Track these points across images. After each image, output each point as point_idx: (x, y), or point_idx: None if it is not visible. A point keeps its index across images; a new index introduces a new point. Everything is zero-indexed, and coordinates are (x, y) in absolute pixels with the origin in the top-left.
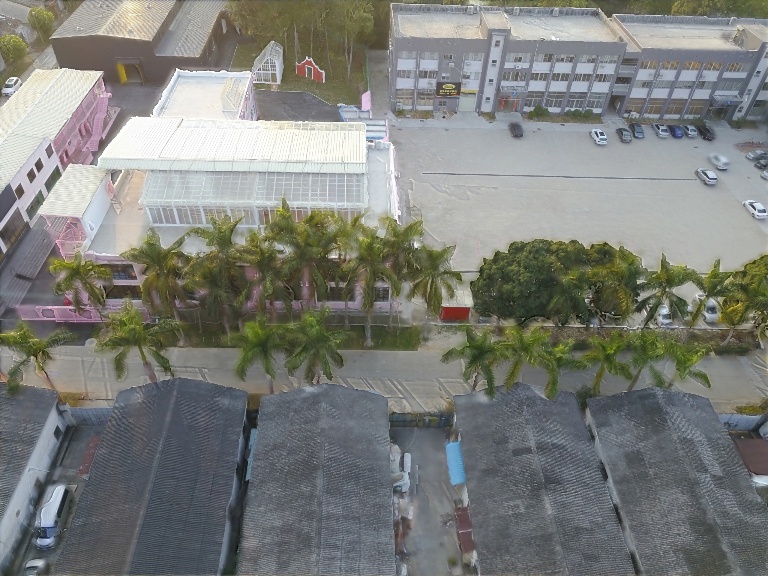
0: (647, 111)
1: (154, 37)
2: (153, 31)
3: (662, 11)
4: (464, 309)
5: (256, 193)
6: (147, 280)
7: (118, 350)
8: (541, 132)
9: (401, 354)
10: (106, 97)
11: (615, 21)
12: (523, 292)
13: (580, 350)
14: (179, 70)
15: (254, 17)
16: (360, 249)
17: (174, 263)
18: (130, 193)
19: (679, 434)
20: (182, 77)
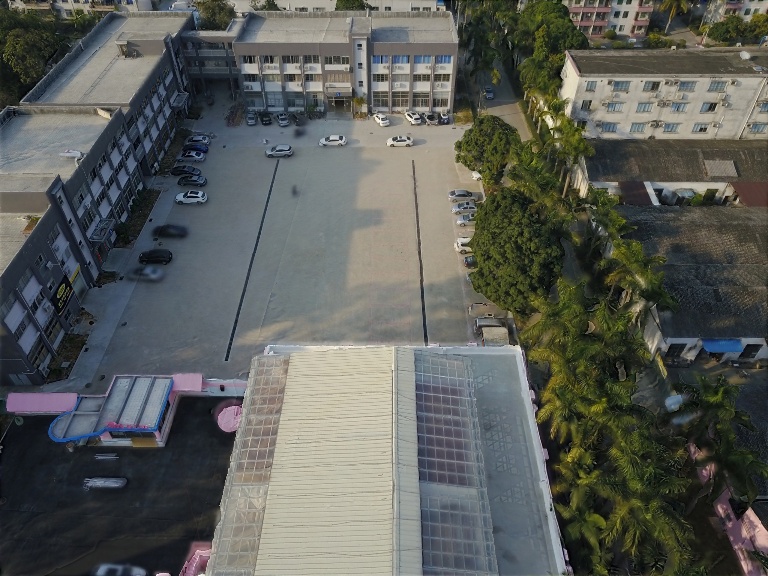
0: None
1: None
2: None
3: None
4: None
5: (462, 486)
6: None
7: None
8: (163, 239)
9: None
10: None
11: None
12: None
13: None
14: None
15: None
16: None
17: None
18: None
19: None
20: None
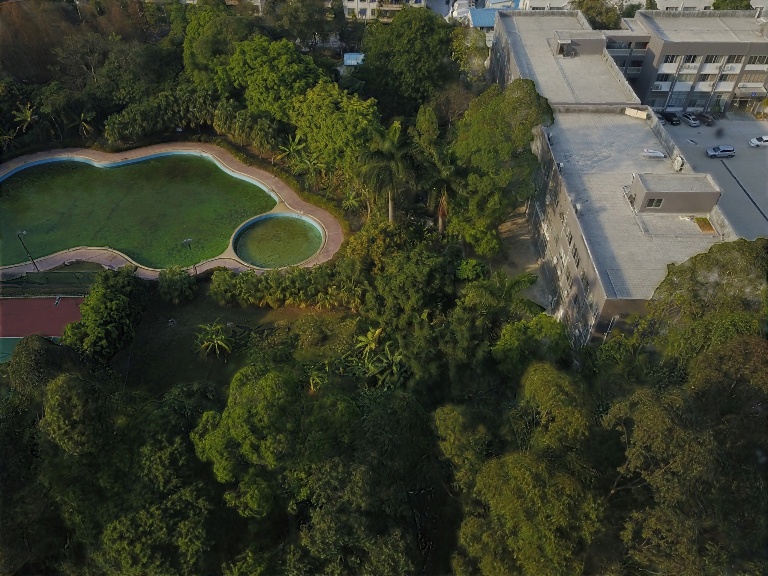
0: None
1: None
2: None
3: (438, 77)
4: None
5: None
6: None
7: None
8: None
9: None
10: None
11: None
12: None
13: None
14: None
15: None
16: None
17: None
18: None
19: None
20: None
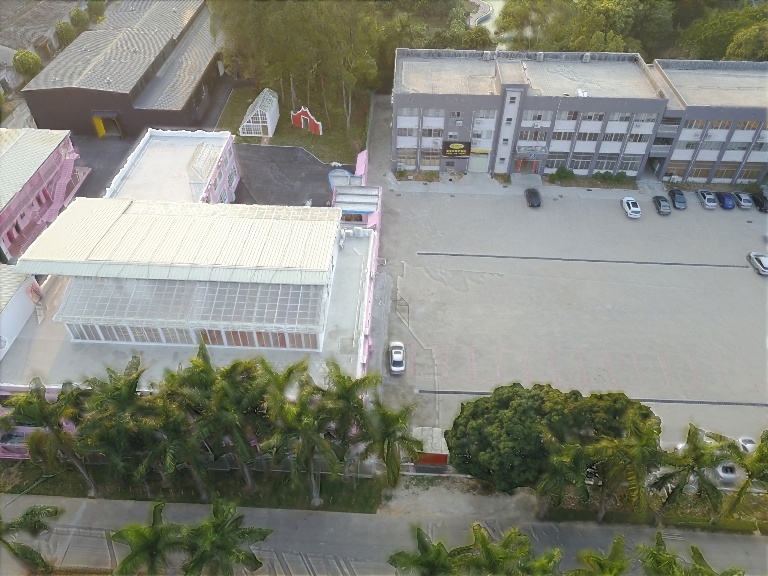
0: (692, 174)
1: (133, 88)
2: (133, 81)
3: (715, 51)
4: (440, 456)
5: (191, 309)
6: (33, 438)
7: (17, 500)
8: (563, 200)
9: (355, 518)
10: (72, 159)
11: (657, 68)
12: (504, 464)
13: (582, 521)
14: (152, 129)
15: (247, 62)
16: (286, 419)
17: (73, 411)
18: (60, 294)
19: None
20: (154, 137)
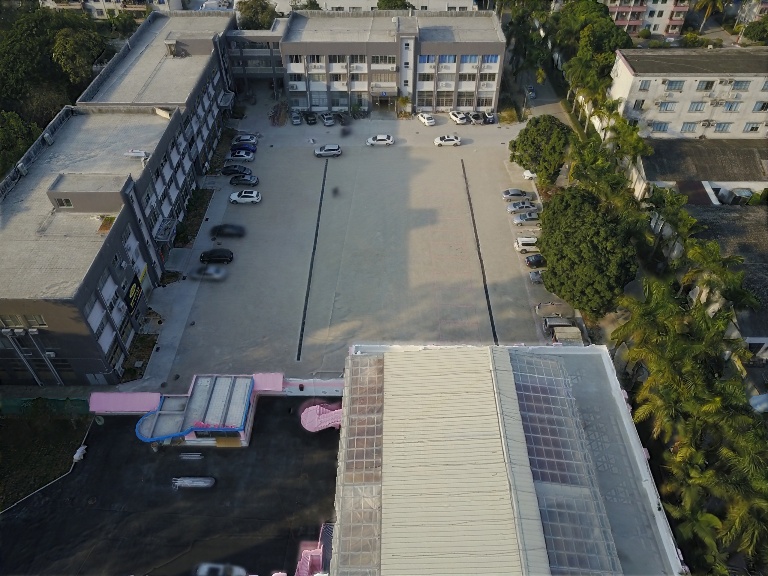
0: None
1: None
2: None
3: (45, 78)
4: None
5: (575, 485)
6: None
7: None
8: (221, 238)
9: None
10: None
11: None
12: None
13: None
14: None
15: None
16: None
17: None
18: None
19: (721, 219)
20: None
